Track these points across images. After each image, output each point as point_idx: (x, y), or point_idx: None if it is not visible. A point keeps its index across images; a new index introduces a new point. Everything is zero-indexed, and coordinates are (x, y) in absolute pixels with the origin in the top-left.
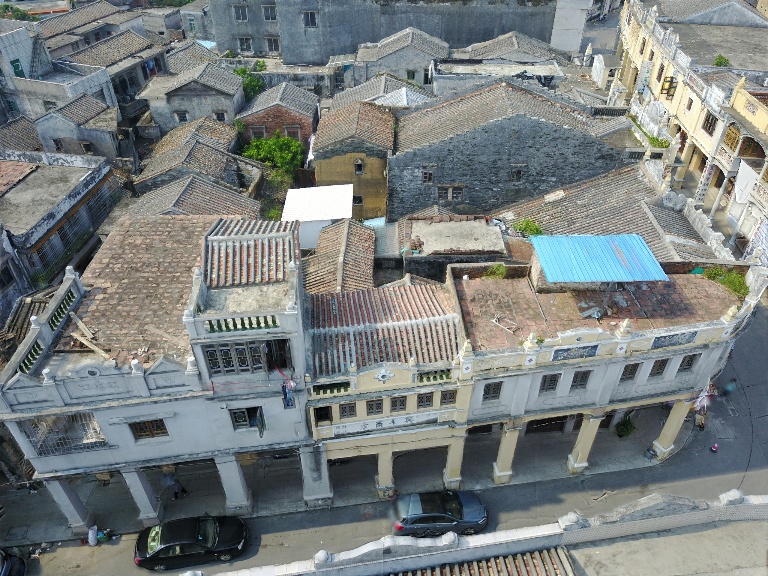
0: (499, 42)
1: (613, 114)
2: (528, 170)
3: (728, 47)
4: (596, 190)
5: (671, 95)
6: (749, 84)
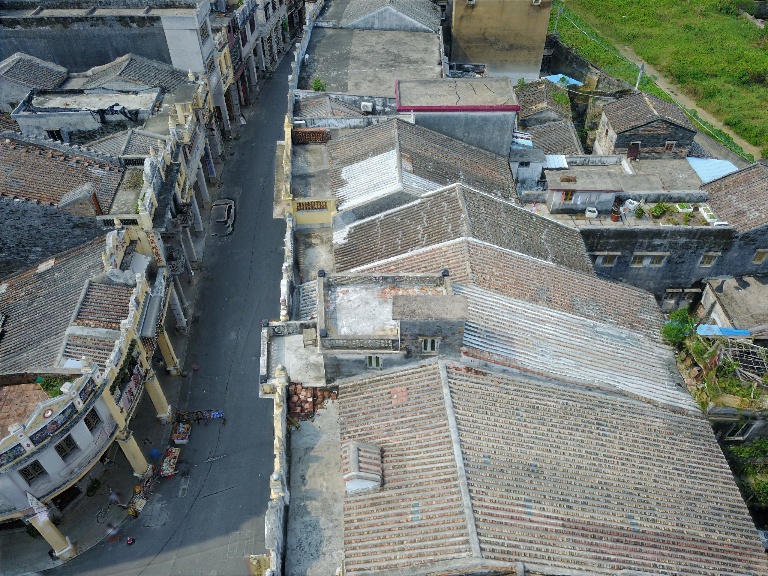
0: (116, 65)
1: None
2: (5, 242)
3: (365, 60)
4: None
5: None
6: (332, 113)
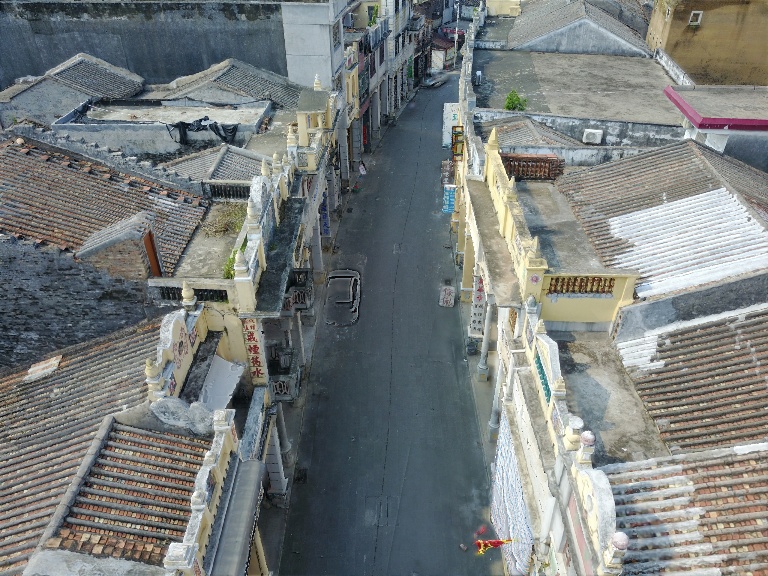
0: (210, 74)
1: (246, 195)
2: None
3: (562, 82)
4: (97, 365)
5: (459, 154)
6: (545, 139)
